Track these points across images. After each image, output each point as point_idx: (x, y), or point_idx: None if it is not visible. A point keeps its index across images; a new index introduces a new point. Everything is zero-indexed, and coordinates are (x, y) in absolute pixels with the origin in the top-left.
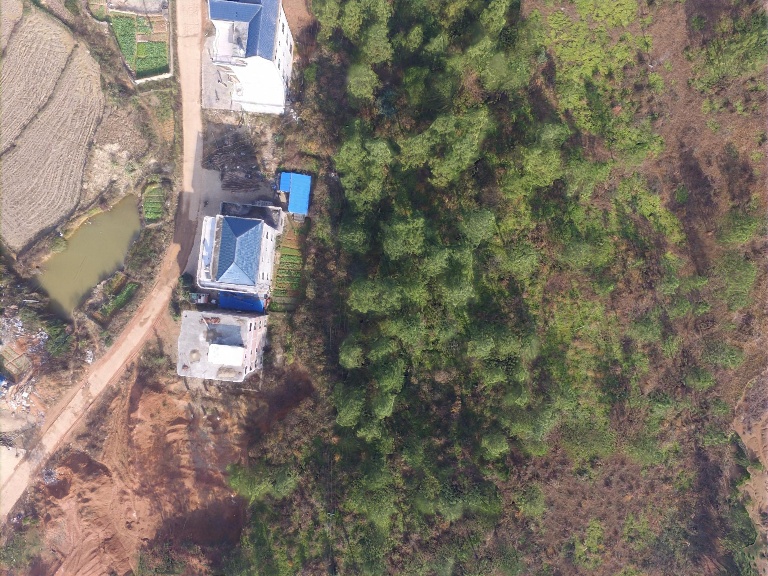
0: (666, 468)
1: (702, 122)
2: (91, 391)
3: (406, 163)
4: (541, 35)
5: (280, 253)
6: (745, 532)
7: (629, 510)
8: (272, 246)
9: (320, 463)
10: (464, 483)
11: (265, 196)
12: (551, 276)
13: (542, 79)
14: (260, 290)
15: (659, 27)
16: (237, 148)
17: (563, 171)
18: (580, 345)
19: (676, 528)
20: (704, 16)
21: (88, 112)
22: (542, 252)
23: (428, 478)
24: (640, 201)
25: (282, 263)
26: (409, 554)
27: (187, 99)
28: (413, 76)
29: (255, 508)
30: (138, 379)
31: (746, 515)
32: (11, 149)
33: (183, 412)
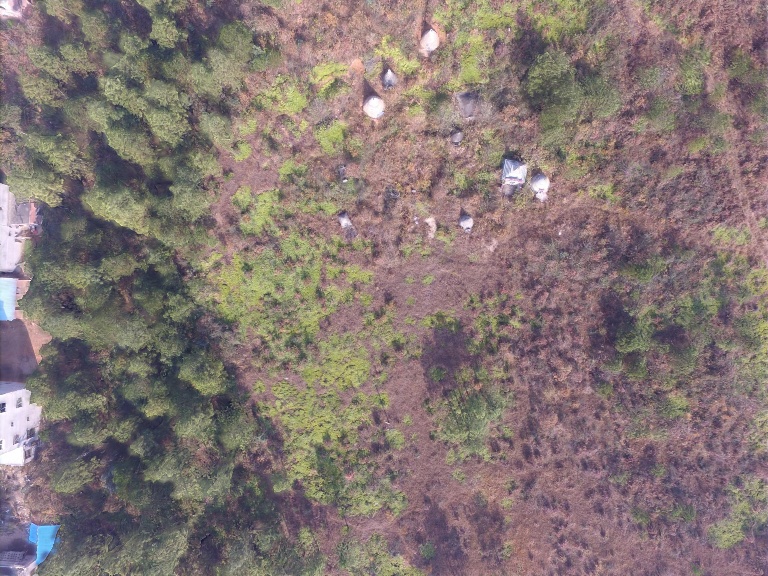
0: None
1: (447, 474)
2: None
3: None
4: (266, 406)
5: None
6: None
7: None
8: None
9: None
10: None
11: (20, 539)
12: None
13: (268, 451)
14: None
15: (394, 383)
16: None
17: (271, 575)
18: None
19: None
20: (443, 367)
21: None
22: None
23: None
24: (379, 565)
25: None
26: None
27: None
28: (116, 481)
29: None
30: None
31: None
32: None
33: None
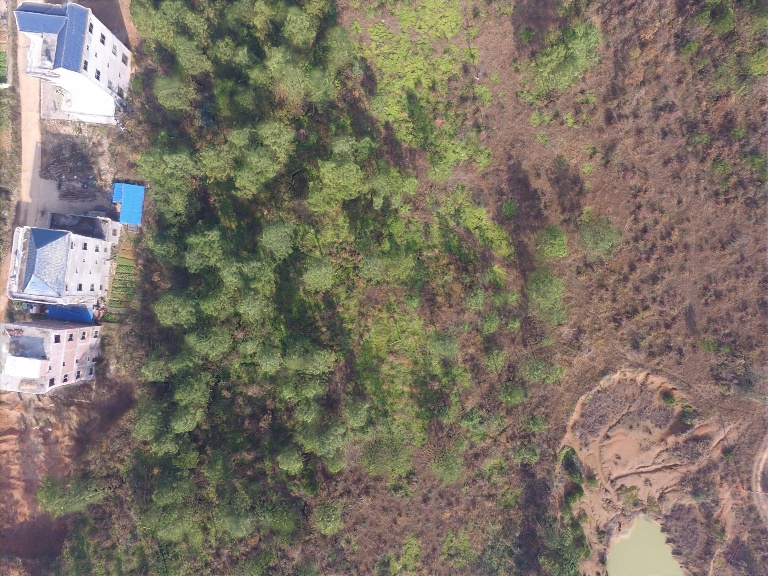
0: (489, 485)
1: (531, 135)
2: None
3: (211, 175)
4: (361, 47)
5: (116, 263)
6: (560, 552)
7: (449, 527)
8: (99, 257)
9: (140, 476)
10: (272, 498)
11: (102, 206)
12: (368, 289)
13: (362, 91)
14: (79, 301)
15: (485, 39)
16: (74, 158)
17: (368, 184)
18: (395, 359)
19: (500, 546)
20: (532, 28)
21: None
22: (360, 265)
23: (238, 493)
24: (464, 214)
25: (117, 273)
26: (219, 570)
27: (26, 109)
28: (219, 88)
29: (78, 521)
30: None
31: (579, 533)
32: None
33: (15, 422)
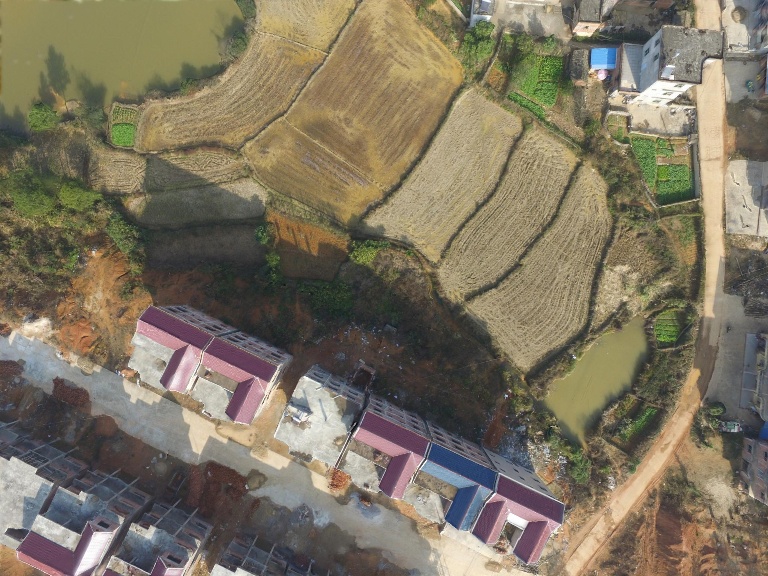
0: None
1: None
2: (613, 517)
3: None
4: None
5: None
6: None
7: None
8: None
9: None
10: None
11: None
12: None
13: None
14: None
15: None
16: (763, 274)
17: None
18: None
19: None
20: None
21: (594, 231)
22: None
23: None
24: None
25: None
26: None
27: (709, 223)
28: None
29: None
30: (665, 507)
31: None
32: (518, 268)
33: (709, 540)
